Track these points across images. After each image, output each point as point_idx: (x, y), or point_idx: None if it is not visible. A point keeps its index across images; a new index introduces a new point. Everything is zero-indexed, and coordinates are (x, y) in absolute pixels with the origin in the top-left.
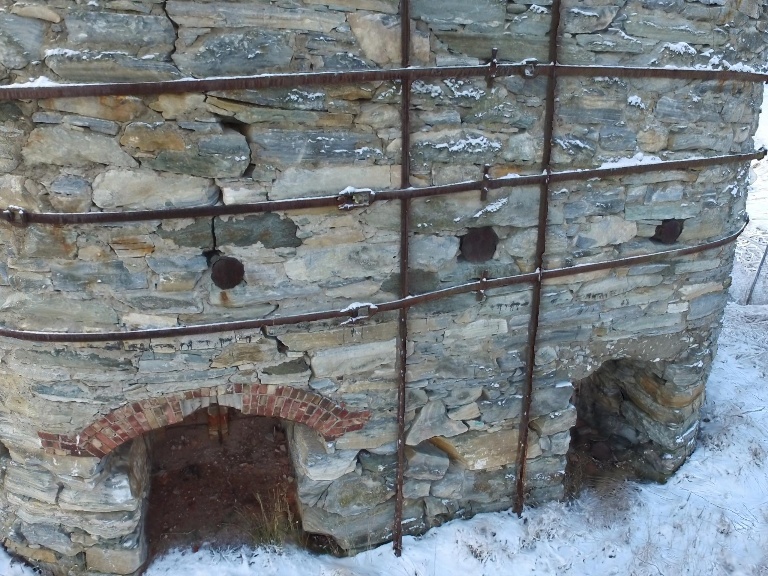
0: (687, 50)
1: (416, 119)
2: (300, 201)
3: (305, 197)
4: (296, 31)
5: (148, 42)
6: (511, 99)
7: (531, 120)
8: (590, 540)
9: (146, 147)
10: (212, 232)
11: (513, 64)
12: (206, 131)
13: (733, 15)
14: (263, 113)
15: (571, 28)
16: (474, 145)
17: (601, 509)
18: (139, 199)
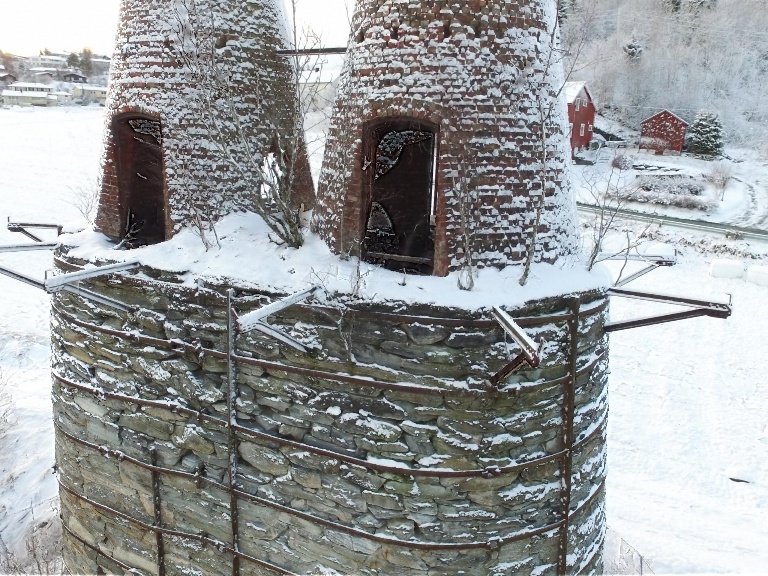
0: (334, 575)
1: (168, 548)
2: (120, 563)
3: (123, 562)
4: (118, 492)
5: (78, 477)
6: (217, 557)
7: (228, 574)
8: None
9: (78, 515)
10: (96, 558)
11: (214, 540)
12: (92, 518)
13: (381, 564)
14: (109, 520)
15: (247, 533)
16: (195, 574)
17: None
18: (78, 532)
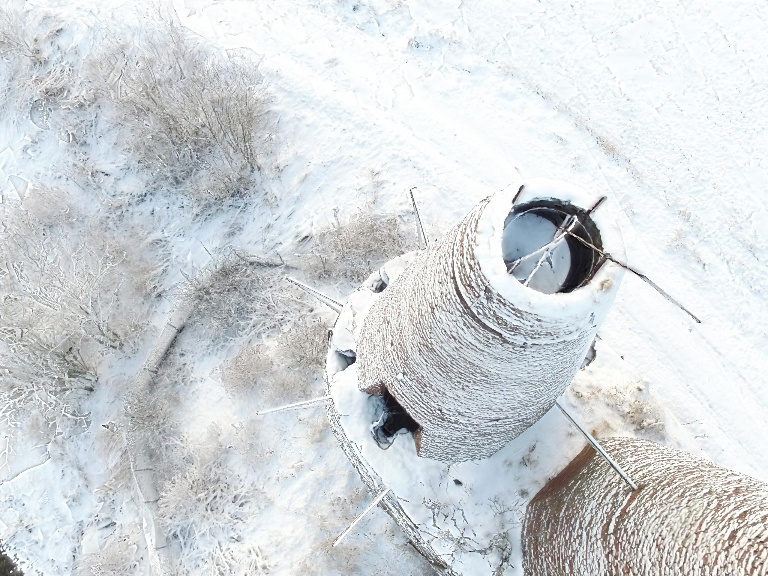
0: None
1: None
2: None
3: None
4: None
5: None
6: None
7: None
8: (415, 568)
9: None
10: None
11: None
12: None
13: None
14: None
15: None
16: None
17: (431, 572)
18: None
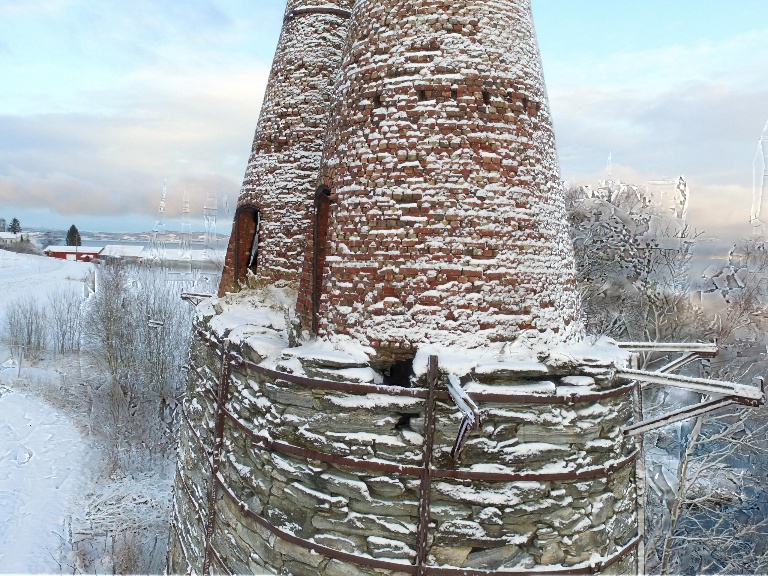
0: None
1: None
2: None
3: None
4: None
5: None
6: None
7: None
8: None
9: None
10: None
11: None
12: None
13: None
14: None
15: None
16: None
17: None
18: None
